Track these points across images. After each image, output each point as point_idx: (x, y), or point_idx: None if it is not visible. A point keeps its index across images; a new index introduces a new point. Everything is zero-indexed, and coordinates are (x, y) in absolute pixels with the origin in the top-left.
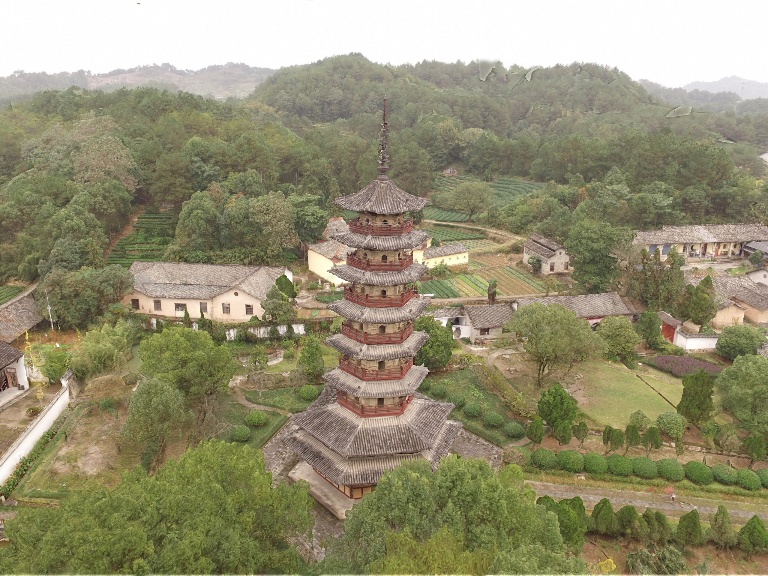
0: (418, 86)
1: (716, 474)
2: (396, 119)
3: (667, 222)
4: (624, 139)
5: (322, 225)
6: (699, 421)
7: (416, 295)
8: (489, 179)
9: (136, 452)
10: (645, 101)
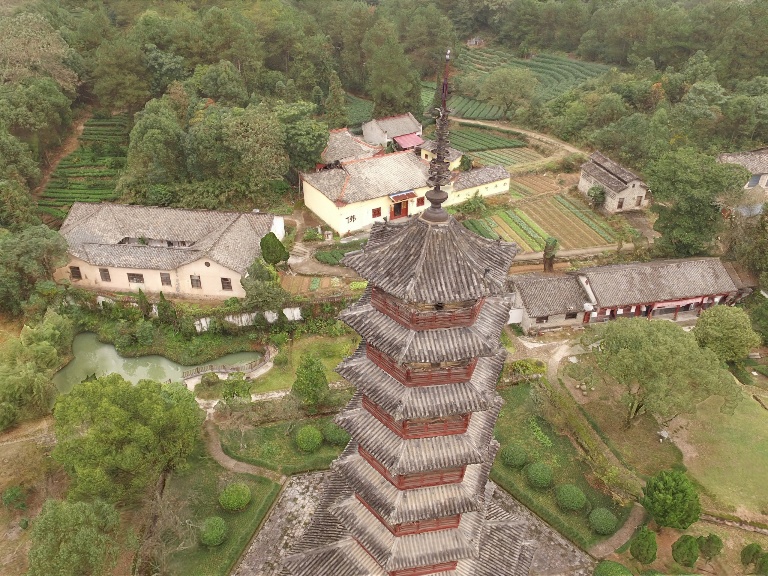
0: None
1: None
2: None
3: (767, 134)
4: (715, 10)
5: (320, 145)
6: None
7: None
8: (525, 55)
9: None
10: None
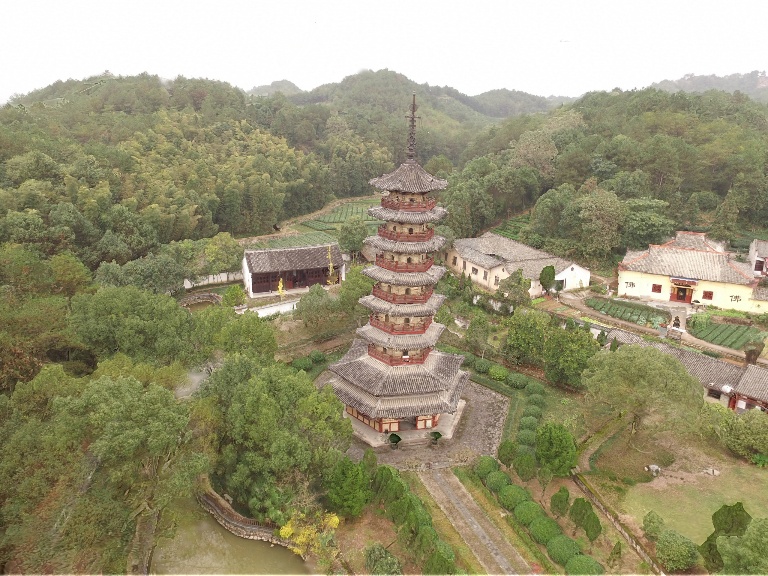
0: None
1: None
2: None
3: None
4: None
5: (657, 234)
6: (715, 572)
7: (664, 324)
8: None
9: (315, 333)
10: None
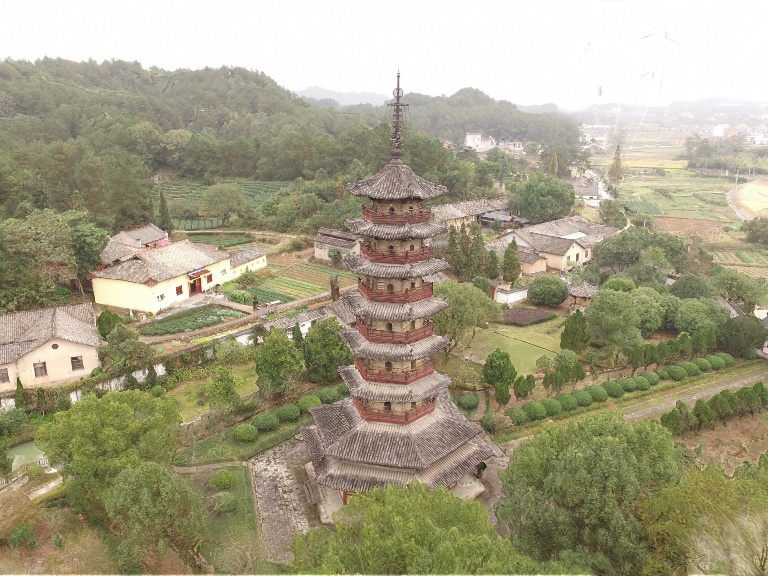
0: (64, 85)
1: (625, 386)
2: (53, 123)
3: None
4: (354, 134)
5: None
6: (581, 352)
7: (263, 305)
8: (211, 182)
9: None
10: (299, 104)
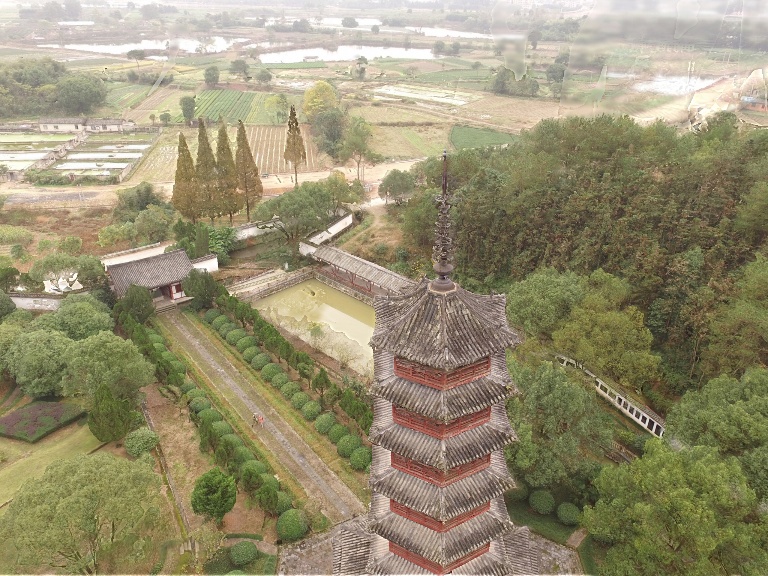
0: None
1: None
2: None
3: None
4: None
5: None
6: None
7: None
8: None
9: None
10: None
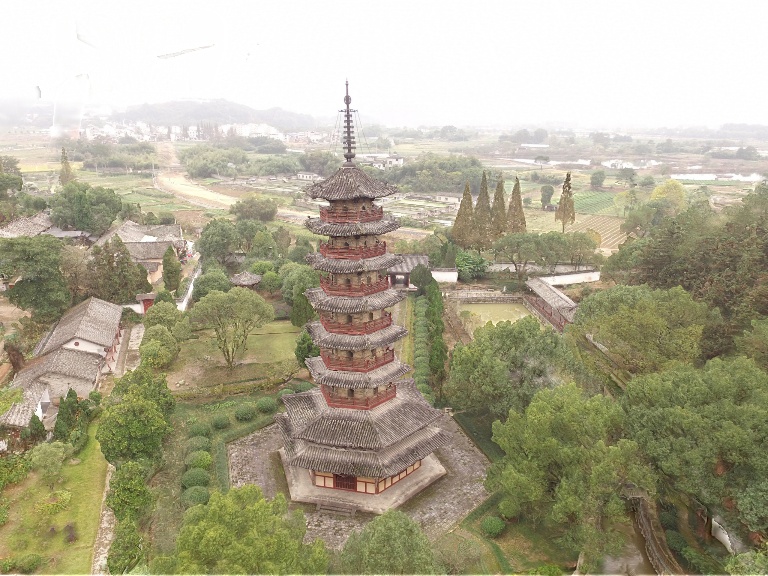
0: None
1: None
2: None
3: None
4: None
5: None
6: None
7: None
8: None
9: None
10: None
